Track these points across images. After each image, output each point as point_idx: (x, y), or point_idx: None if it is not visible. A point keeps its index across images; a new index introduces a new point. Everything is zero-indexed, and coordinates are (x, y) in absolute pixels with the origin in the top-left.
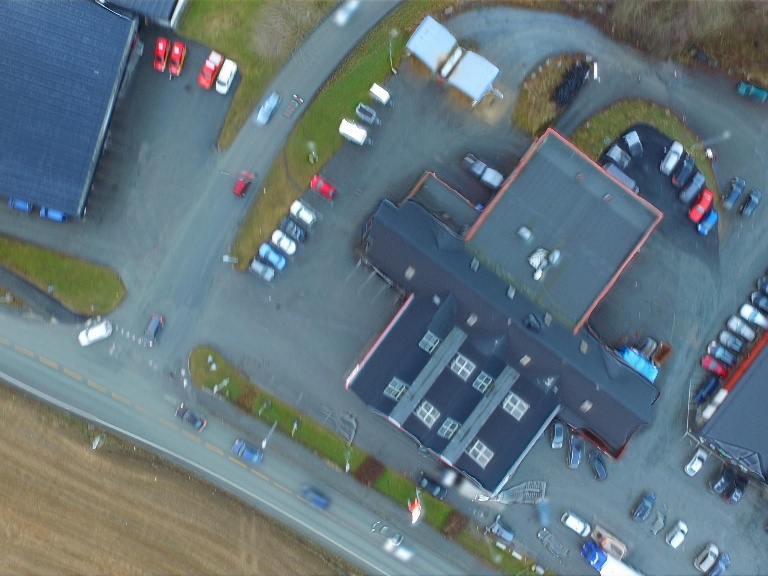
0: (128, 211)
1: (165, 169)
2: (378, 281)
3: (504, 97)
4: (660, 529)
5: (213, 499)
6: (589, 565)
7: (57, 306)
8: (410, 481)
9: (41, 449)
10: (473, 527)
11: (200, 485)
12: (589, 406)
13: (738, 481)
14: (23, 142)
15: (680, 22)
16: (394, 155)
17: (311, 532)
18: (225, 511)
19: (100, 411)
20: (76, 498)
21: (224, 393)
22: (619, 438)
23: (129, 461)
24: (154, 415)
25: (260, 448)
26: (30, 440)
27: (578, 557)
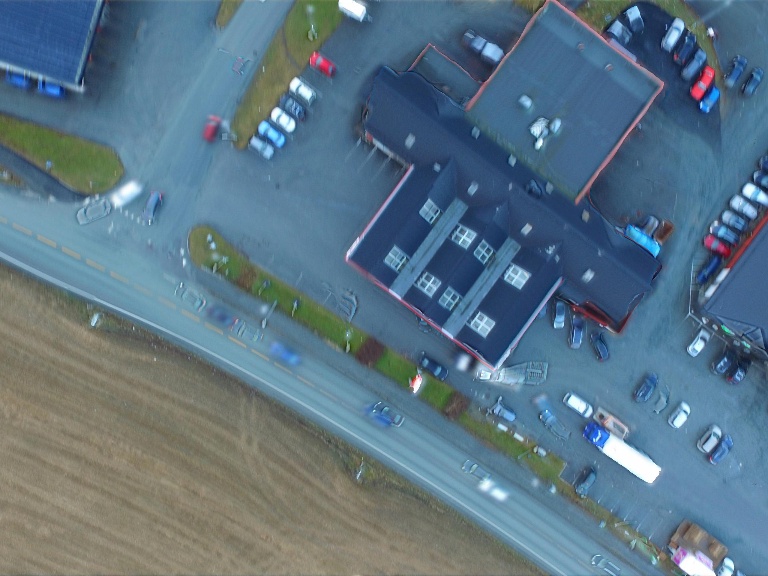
0: (126, 89)
1: (163, 46)
2: (378, 159)
3: None
4: (663, 408)
5: (213, 379)
6: (591, 446)
7: (55, 184)
8: (411, 362)
9: (39, 329)
10: (474, 408)
11: (200, 365)
12: (591, 275)
13: (741, 361)
14: (20, 7)
15: None
16: (394, 33)
17: (312, 412)
18: (225, 392)
19: (99, 290)
20: (75, 378)
21: (223, 272)
22: (621, 310)
23: (128, 341)
24: (153, 294)
25: (260, 328)
26: (28, 320)
27: (580, 439)
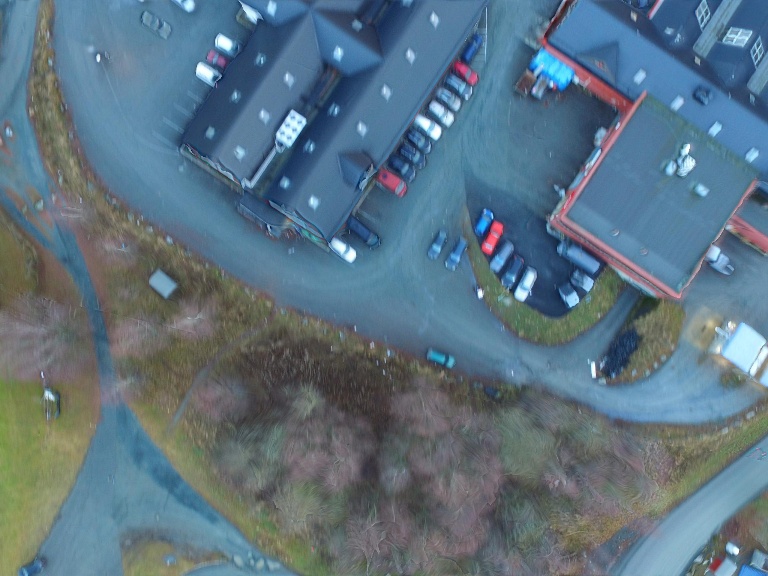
0: None
1: None
2: None
3: (694, 334)
4: None
5: None
6: None
7: None
8: None
9: None
10: None
11: None
12: (633, 16)
13: None
14: None
15: (544, 416)
16: None
17: None
18: None
19: None
20: None
21: None
22: None
23: None
24: None
25: None
26: None
27: None
